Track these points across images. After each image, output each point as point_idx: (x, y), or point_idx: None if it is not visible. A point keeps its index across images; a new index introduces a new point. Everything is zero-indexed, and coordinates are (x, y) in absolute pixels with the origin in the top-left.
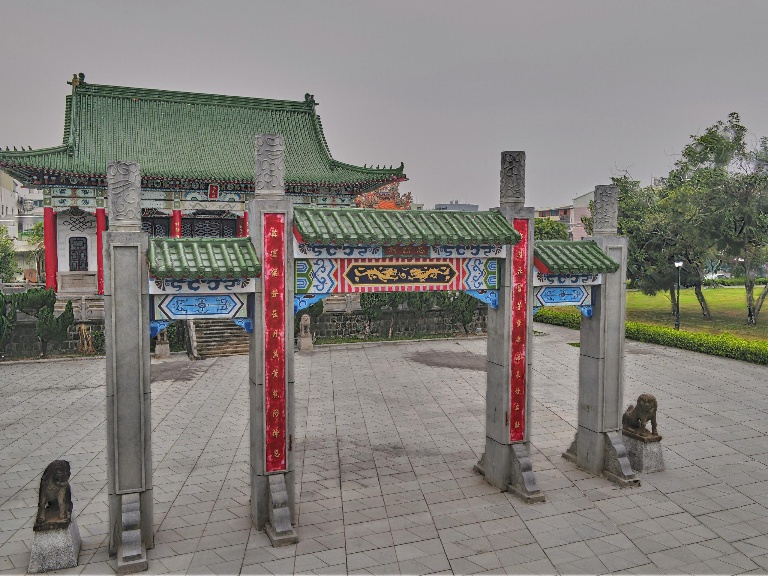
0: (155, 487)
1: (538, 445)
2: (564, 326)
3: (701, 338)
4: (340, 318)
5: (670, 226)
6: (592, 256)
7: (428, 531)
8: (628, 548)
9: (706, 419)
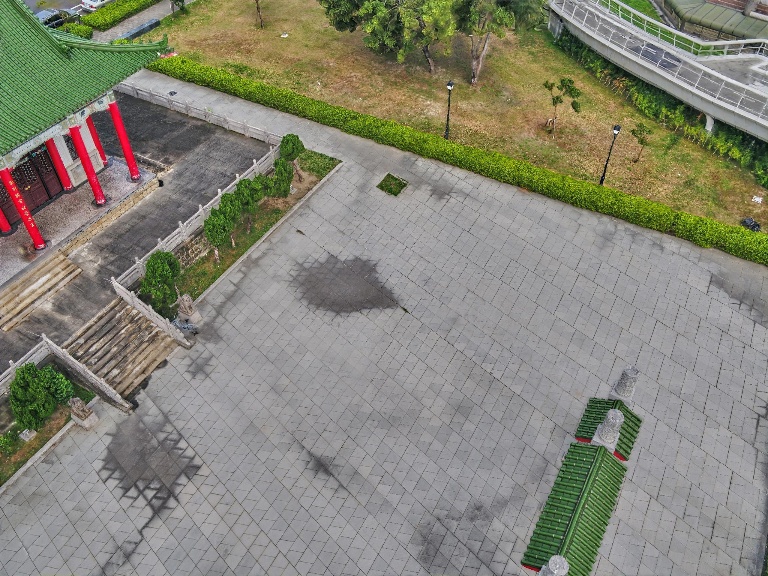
0: None
1: (538, 450)
2: (334, 127)
3: (480, 163)
4: (183, 252)
5: (431, 34)
6: (628, 419)
7: None
8: (658, 555)
9: (577, 344)
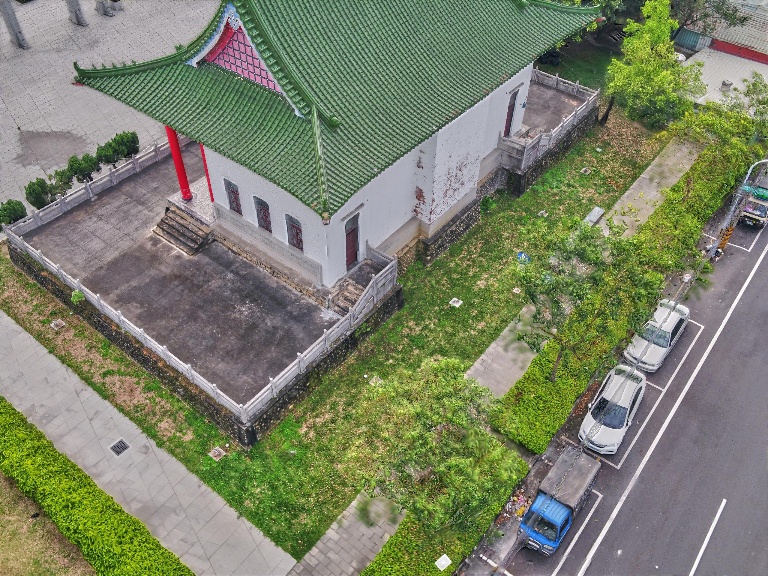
0: (119, 23)
1: (7, 63)
2: None
3: None
4: None
5: None
6: None
7: (40, 27)
8: None
9: None
